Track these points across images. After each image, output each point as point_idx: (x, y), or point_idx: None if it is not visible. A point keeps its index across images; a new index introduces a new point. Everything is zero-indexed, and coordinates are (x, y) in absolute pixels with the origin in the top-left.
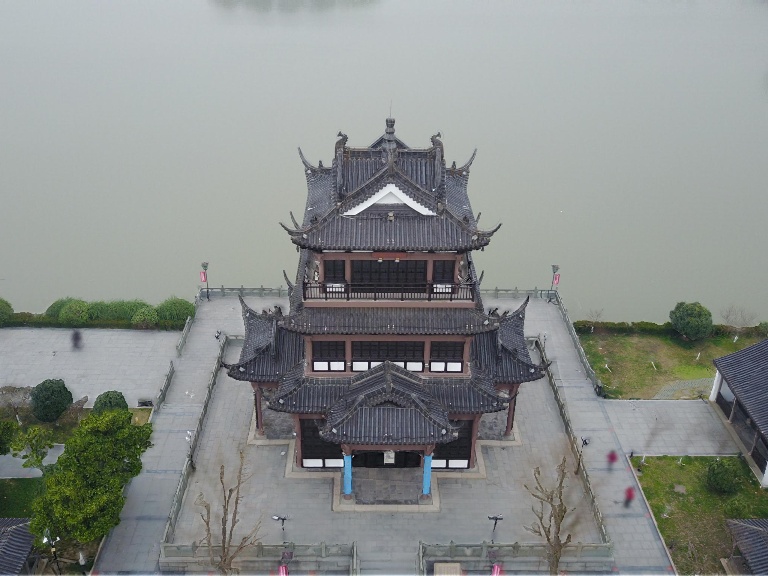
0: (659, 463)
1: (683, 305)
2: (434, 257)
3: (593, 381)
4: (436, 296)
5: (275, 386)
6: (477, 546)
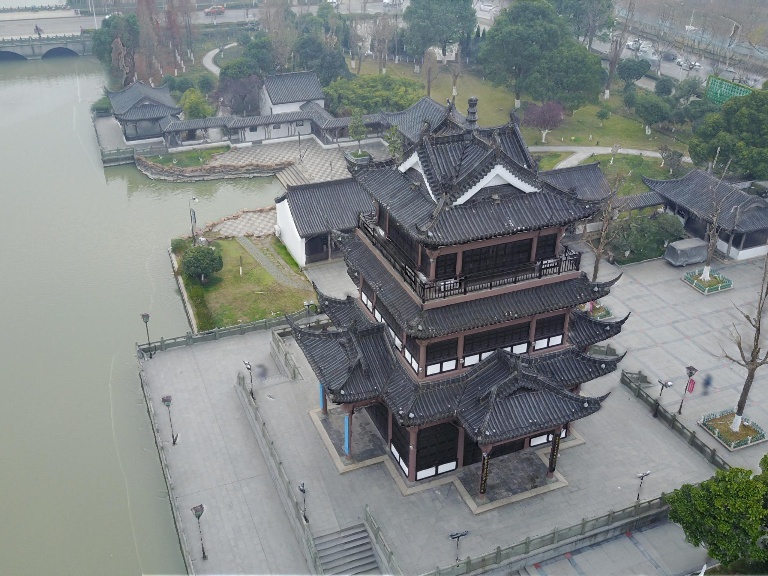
0: None
1: (196, 256)
2: None
3: None
4: None
5: None
6: None
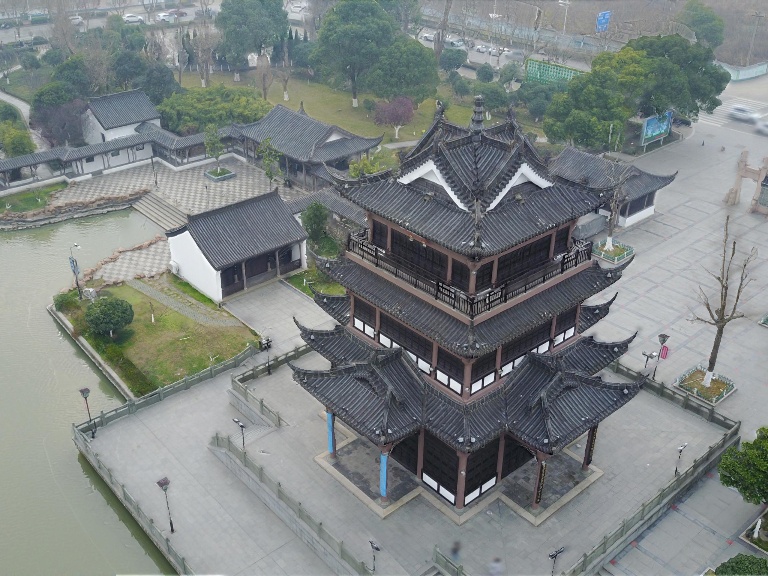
0: None
1: (104, 310)
2: None
3: None
4: None
5: None
6: None
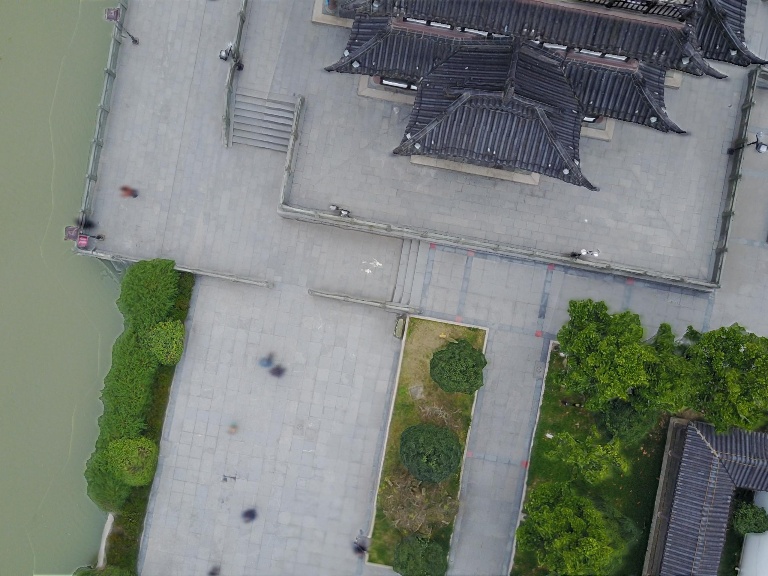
0: None
1: None
2: None
3: None
4: None
5: None
6: None
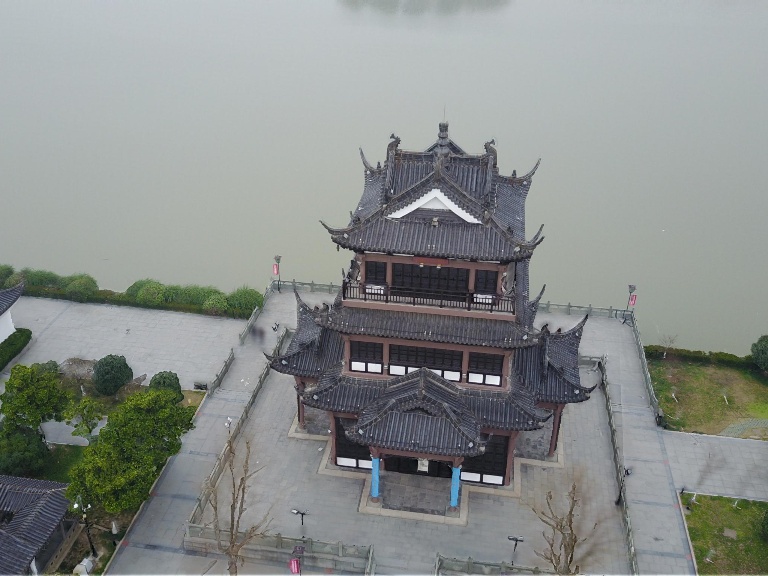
0: (712, 503)
1: (767, 338)
2: (476, 266)
3: (655, 409)
4: (476, 306)
5: (316, 382)
6: (496, 565)
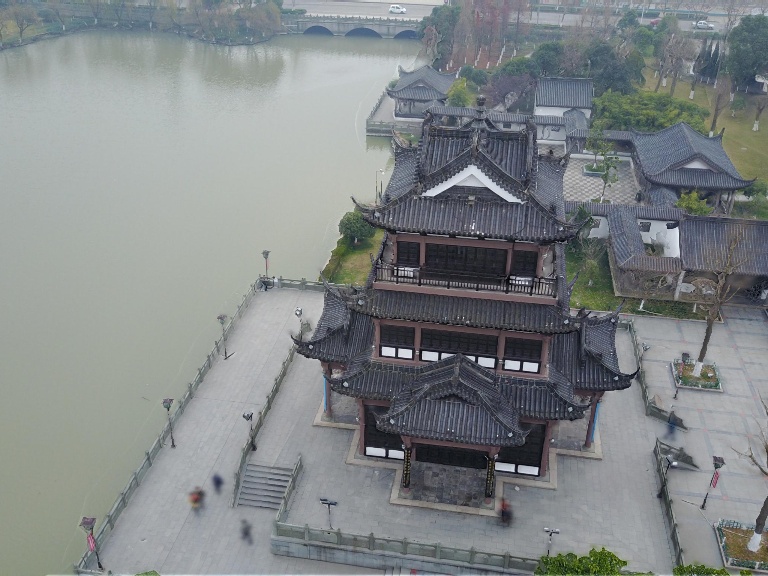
0: None
1: (350, 218)
2: None
3: None
4: None
5: None
6: None
